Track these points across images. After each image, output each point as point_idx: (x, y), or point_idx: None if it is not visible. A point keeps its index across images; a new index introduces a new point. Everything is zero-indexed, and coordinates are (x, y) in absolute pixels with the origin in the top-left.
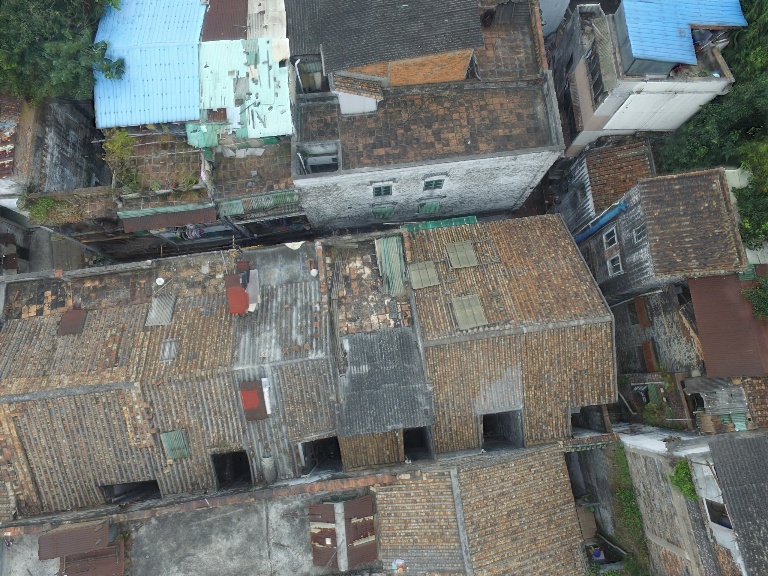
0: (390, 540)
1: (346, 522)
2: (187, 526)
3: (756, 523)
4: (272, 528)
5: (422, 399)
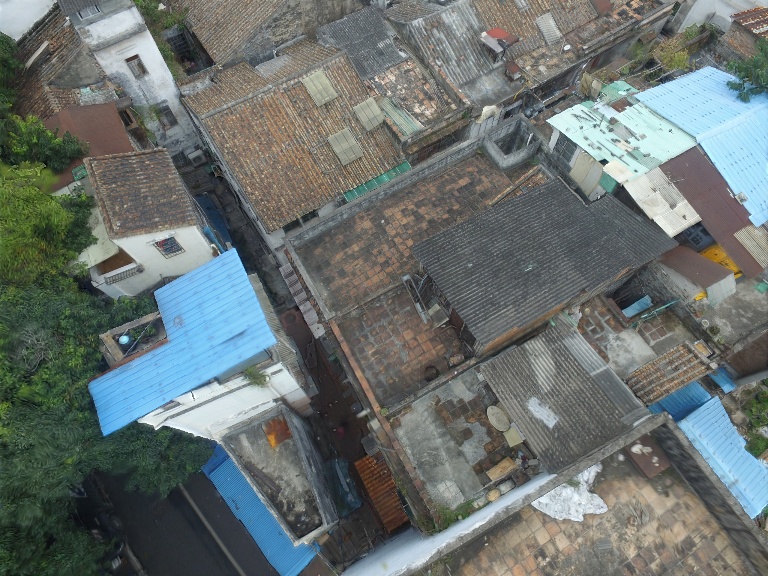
0: None
1: None
2: None
3: None
4: None
5: (330, 40)
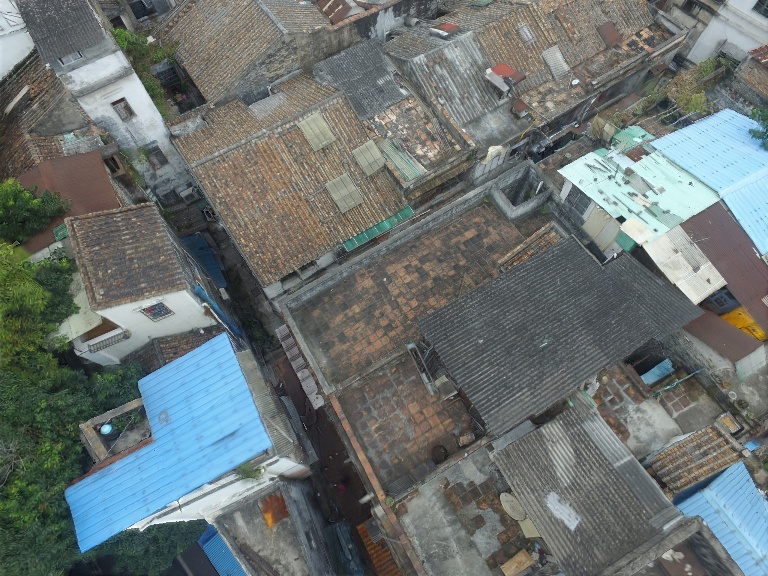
0: None
1: (345, 2)
2: None
3: (70, 7)
4: None
5: (328, 77)
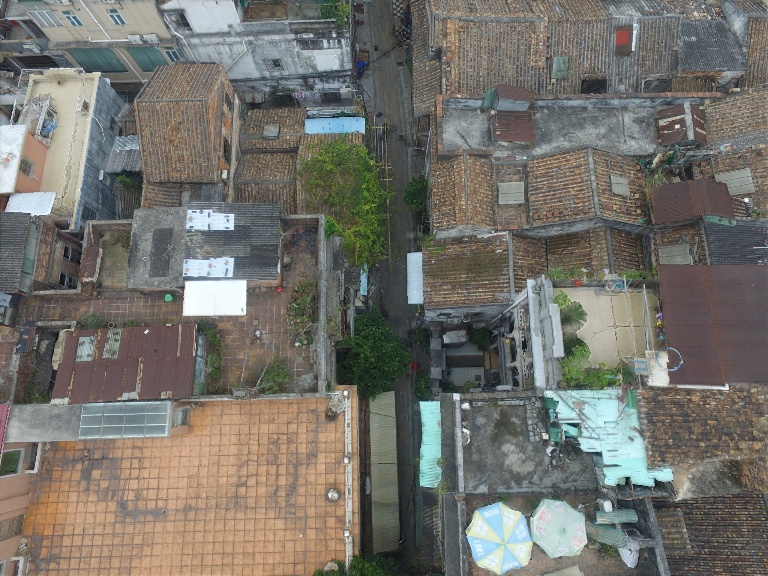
0: (718, 134)
1: (692, 114)
2: (569, 117)
3: None
4: (627, 127)
5: (739, 57)
